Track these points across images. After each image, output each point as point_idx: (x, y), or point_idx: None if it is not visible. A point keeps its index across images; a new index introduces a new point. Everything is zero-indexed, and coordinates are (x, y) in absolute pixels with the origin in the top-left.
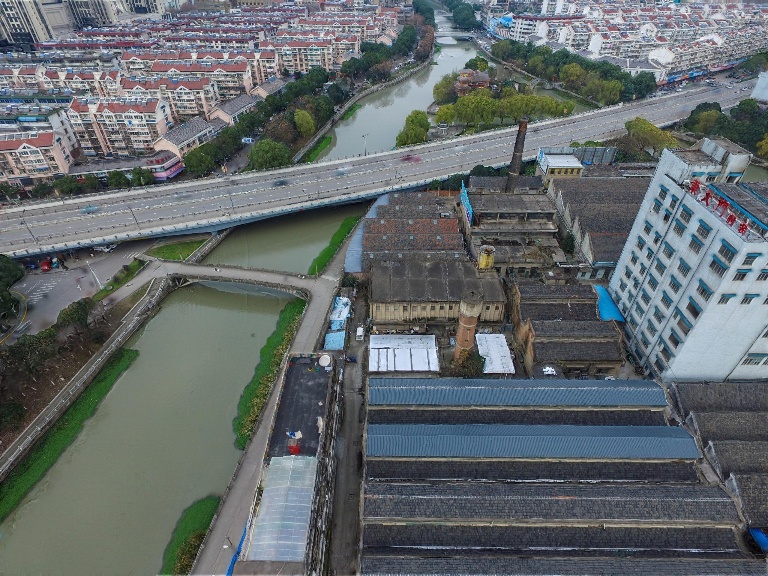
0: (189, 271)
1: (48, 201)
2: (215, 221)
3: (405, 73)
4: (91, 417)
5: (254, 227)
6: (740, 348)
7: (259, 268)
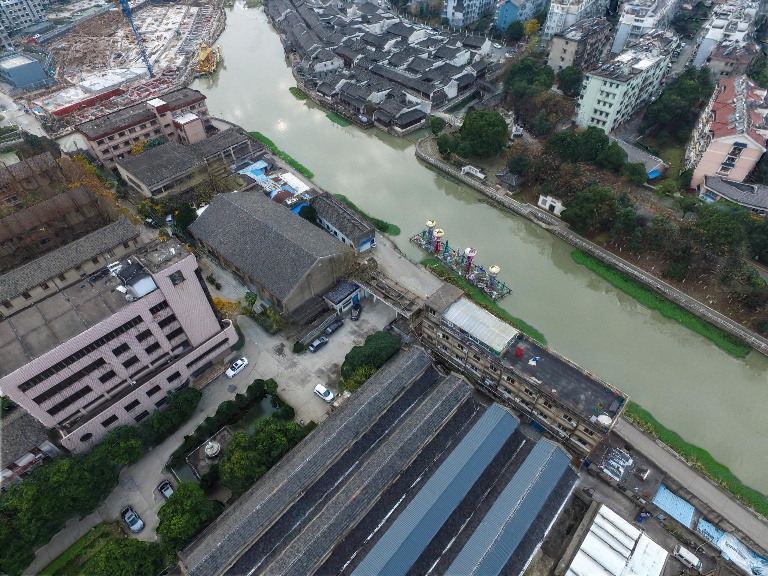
0: None
1: None
2: None
3: None
4: (662, 315)
5: None
6: None
7: None
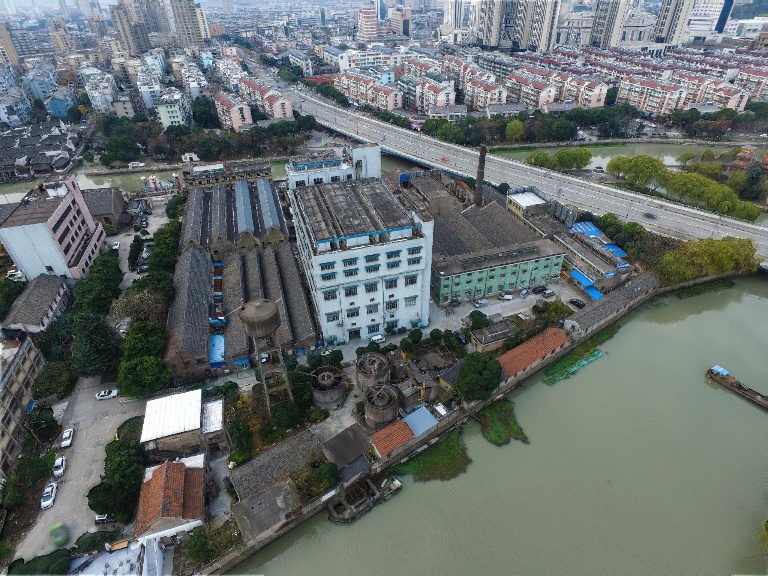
0: None
1: (369, 118)
2: None
3: (760, 142)
4: None
5: (393, 158)
6: None
7: None
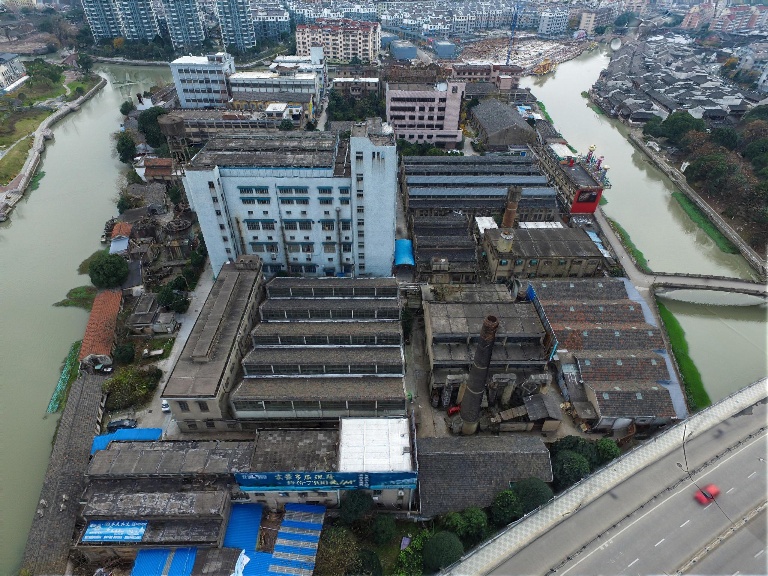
0: None
1: None
2: None
3: None
4: None
5: None
6: None
7: (712, 286)
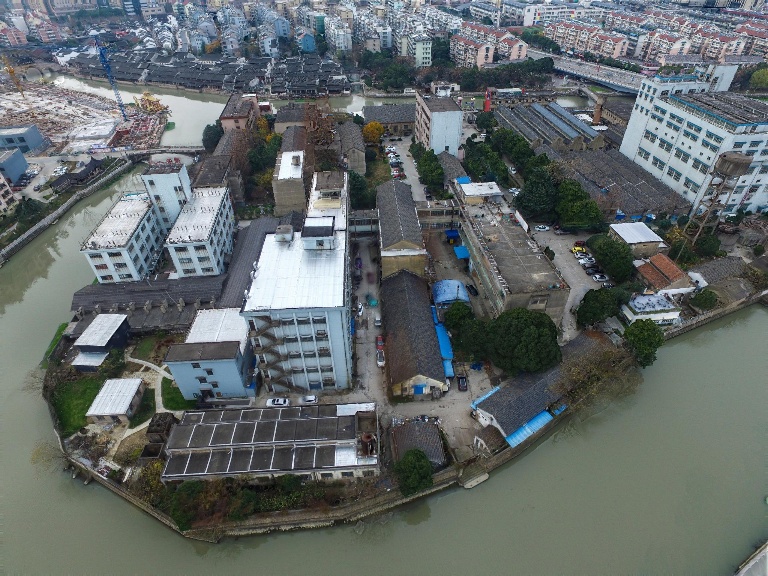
0: None
1: (595, 64)
2: (620, 84)
3: None
4: None
5: None
6: (638, 142)
7: None
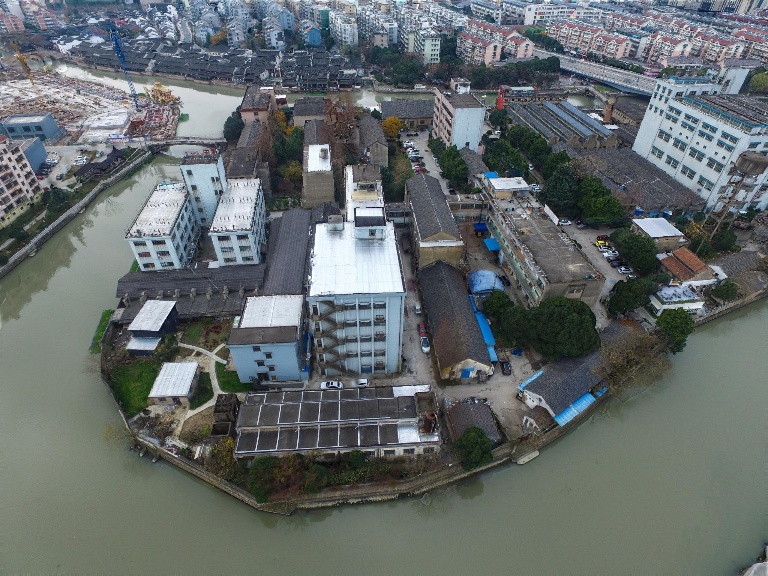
0: (592, 90)
1: (598, 64)
2: (625, 85)
3: None
4: None
5: (640, 99)
6: None
7: None
